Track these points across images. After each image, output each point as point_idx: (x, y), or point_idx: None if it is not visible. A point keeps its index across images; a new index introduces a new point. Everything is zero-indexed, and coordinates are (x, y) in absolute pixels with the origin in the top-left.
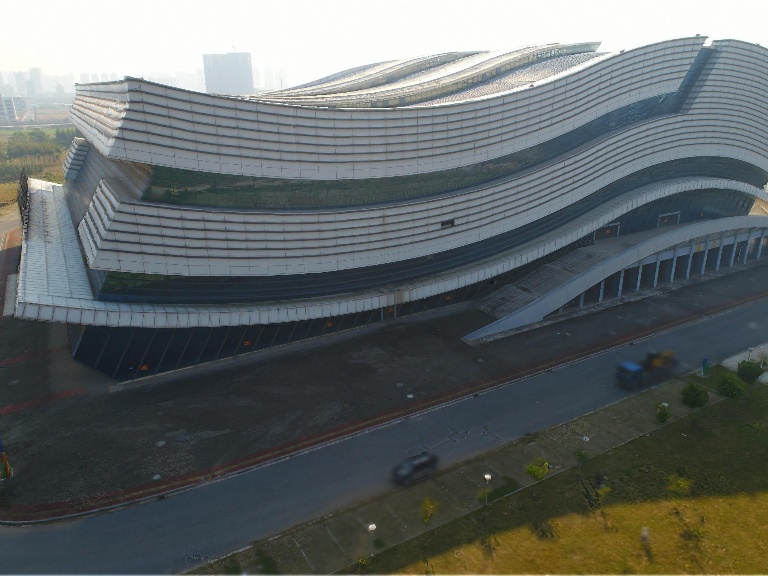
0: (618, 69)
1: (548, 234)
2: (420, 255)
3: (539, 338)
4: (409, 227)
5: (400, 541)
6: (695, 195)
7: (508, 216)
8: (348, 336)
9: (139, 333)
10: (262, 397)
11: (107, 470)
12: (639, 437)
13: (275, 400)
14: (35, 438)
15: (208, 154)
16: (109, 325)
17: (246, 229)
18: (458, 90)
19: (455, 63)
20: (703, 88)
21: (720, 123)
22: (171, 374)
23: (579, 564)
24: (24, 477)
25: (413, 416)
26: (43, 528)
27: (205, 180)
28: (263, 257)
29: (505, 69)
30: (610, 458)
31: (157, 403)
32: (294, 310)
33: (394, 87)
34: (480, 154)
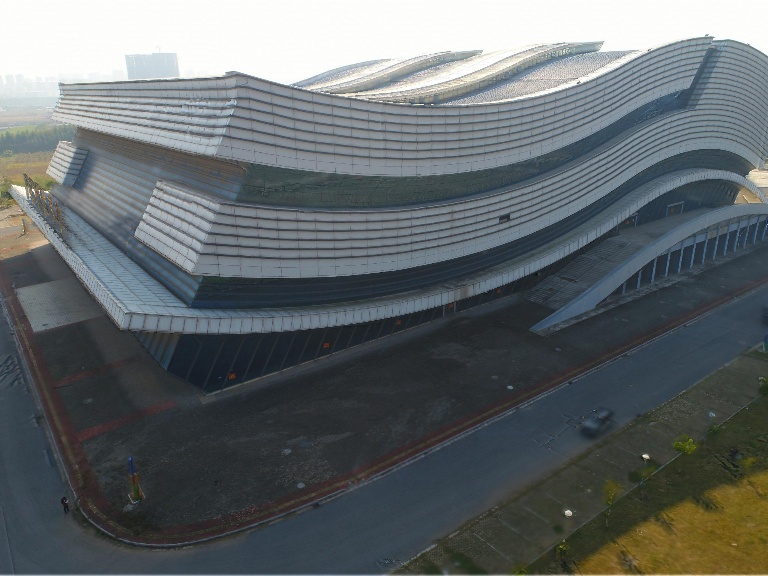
0: (646, 67)
1: (582, 226)
2: (481, 250)
3: (600, 325)
4: (473, 222)
5: (579, 525)
6: (695, 186)
7: (554, 209)
8: (418, 333)
9: (231, 340)
10: (366, 398)
11: (246, 483)
12: (741, 410)
13: (381, 400)
14: (148, 456)
15: (306, 152)
16: (209, 333)
17: (334, 228)
18: (485, 88)
19: (469, 62)
20: (707, 85)
21: (718, 118)
22: (258, 381)
23: (755, 530)
24: (159, 497)
25: (522, 406)
26: (208, 548)
27: (297, 179)
28: (348, 256)
29: (524, 67)
30: (726, 432)
31: (261, 411)
32: (375, 309)
33: (422, 85)
34: (536, 149)
